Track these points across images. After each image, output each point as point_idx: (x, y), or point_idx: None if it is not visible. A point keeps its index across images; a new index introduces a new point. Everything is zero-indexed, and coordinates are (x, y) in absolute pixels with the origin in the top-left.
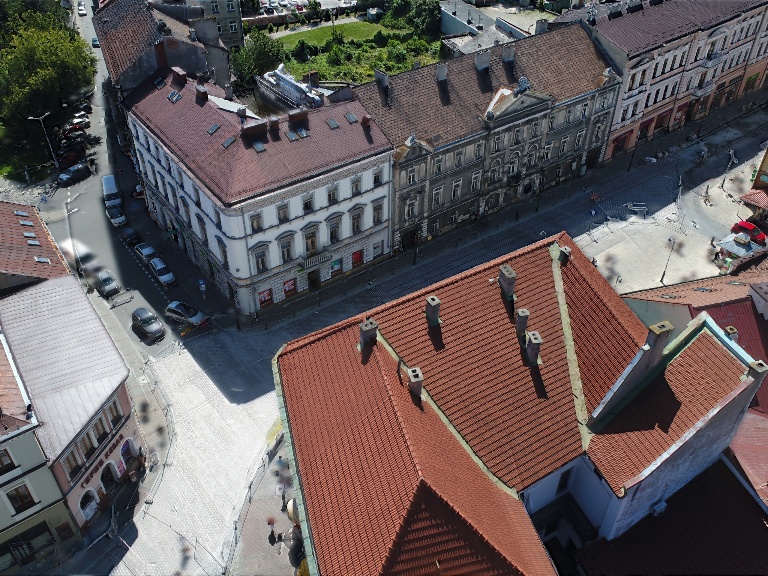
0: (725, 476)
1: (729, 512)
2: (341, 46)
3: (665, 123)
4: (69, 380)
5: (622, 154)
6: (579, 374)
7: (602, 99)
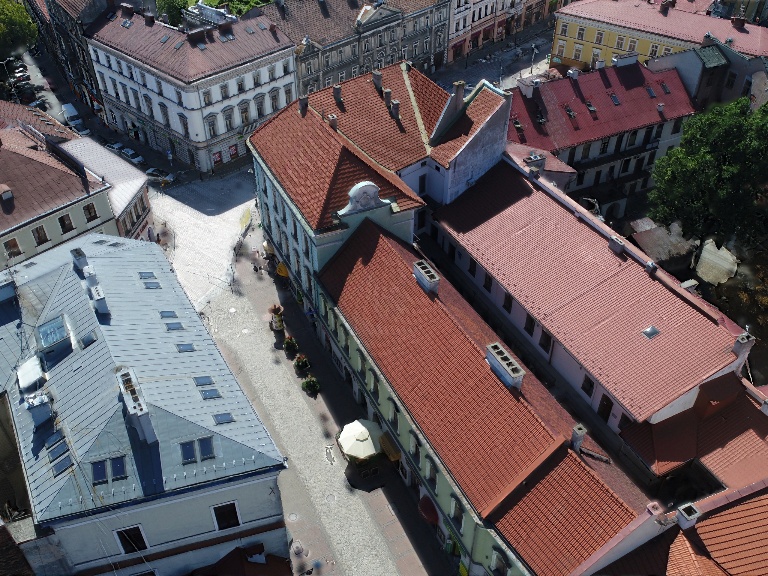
0: (505, 165)
1: (507, 179)
2: (232, 4)
3: (491, 36)
4: (112, 182)
5: (461, 59)
6: (422, 122)
7: (439, 13)
